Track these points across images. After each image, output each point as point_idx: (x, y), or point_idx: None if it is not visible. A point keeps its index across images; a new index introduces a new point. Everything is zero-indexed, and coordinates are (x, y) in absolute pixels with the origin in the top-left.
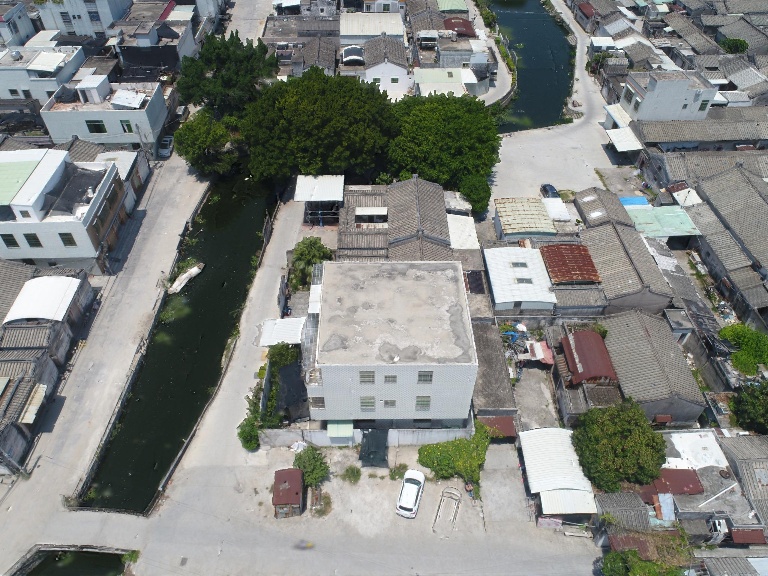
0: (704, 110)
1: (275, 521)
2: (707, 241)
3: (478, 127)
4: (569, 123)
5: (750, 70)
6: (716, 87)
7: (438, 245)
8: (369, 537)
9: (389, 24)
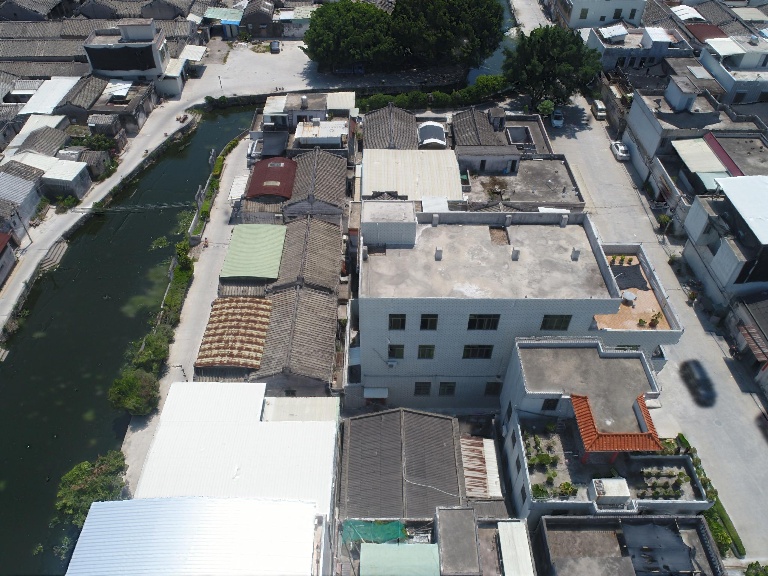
0: None
1: None
2: None
3: (328, 5)
4: None
5: None
6: None
7: None
8: None
9: (383, 159)
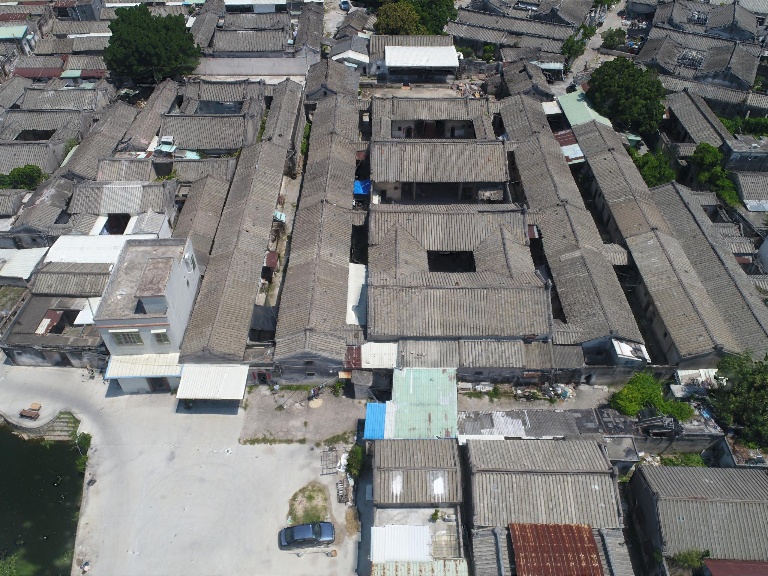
0: (195, 267)
1: None
2: (471, 367)
3: None
4: (90, 443)
5: (109, 189)
6: (103, 231)
7: None
8: None
9: None
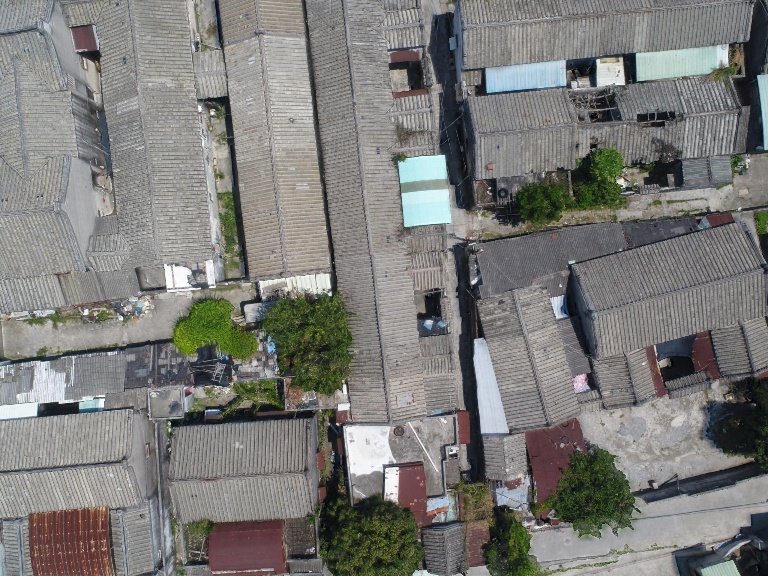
0: None
1: None
2: None
3: None
4: None
5: None
6: None
7: None
8: None
9: None
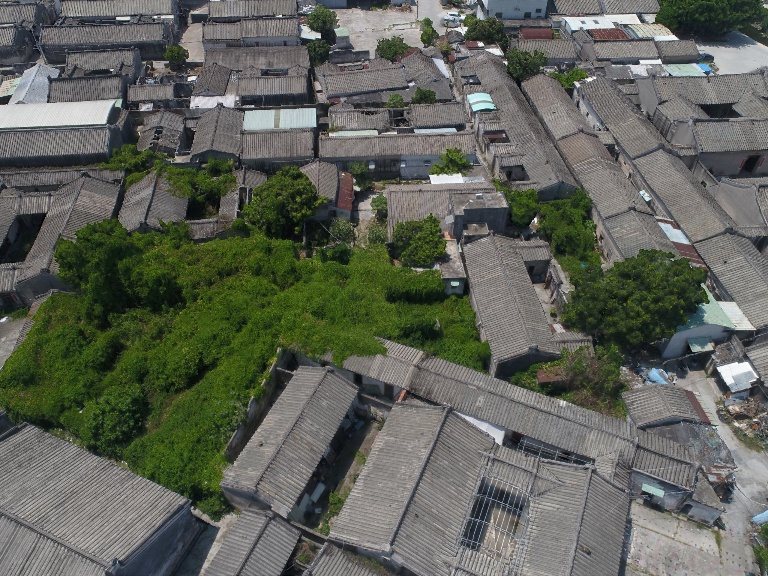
0: None
1: (439, 2)
2: None
3: None
4: None
5: None
6: None
7: (599, 6)
8: (437, 15)
9: None
